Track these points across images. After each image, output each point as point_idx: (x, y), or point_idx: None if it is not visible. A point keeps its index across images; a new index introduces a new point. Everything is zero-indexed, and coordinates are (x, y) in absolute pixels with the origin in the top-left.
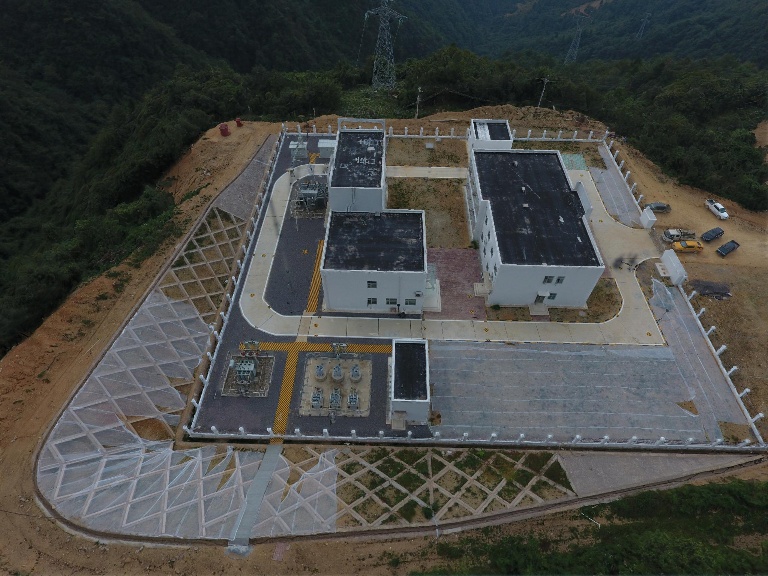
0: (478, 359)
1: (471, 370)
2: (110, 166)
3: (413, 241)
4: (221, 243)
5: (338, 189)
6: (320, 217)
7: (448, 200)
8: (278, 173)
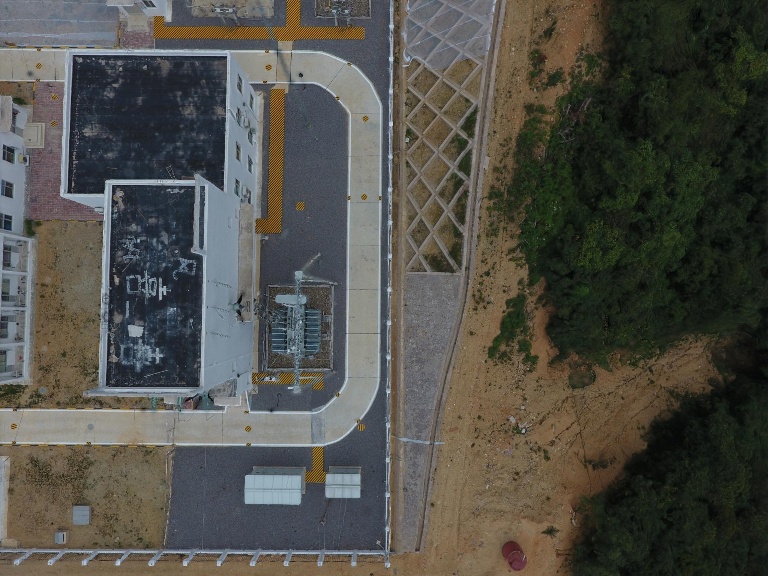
0: (56, 20)
1: (67, 3)
2: (749, 568)
3: (89, 130)
4: (430, 202)
5: (190, 181)
6: (285, 287)
7: (62, 342)
8: (378, 414)
